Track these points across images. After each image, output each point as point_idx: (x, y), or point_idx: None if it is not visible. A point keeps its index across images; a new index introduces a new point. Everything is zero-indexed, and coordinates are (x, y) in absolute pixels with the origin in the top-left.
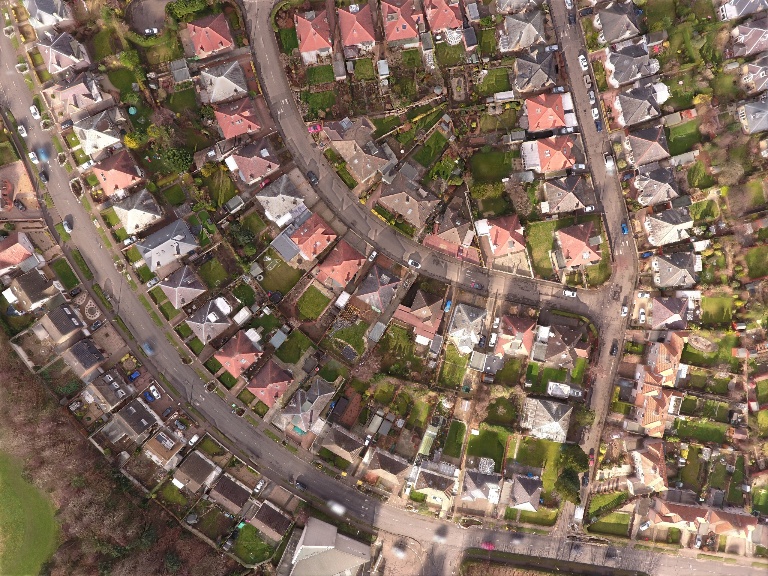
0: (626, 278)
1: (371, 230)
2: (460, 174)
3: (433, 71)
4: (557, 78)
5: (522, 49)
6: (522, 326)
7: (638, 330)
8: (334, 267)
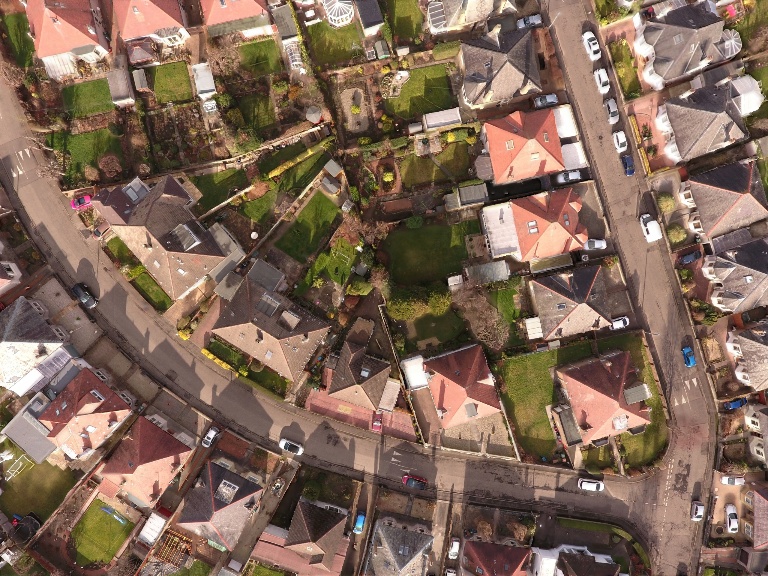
0: (696, 448)
1: (205, 387)
2: (366, 273)
3: (305, 79)
4: (543, 78)
5: (472, 26)
6: (502, 565)
7: (725, 545)
8: (123, 475)
